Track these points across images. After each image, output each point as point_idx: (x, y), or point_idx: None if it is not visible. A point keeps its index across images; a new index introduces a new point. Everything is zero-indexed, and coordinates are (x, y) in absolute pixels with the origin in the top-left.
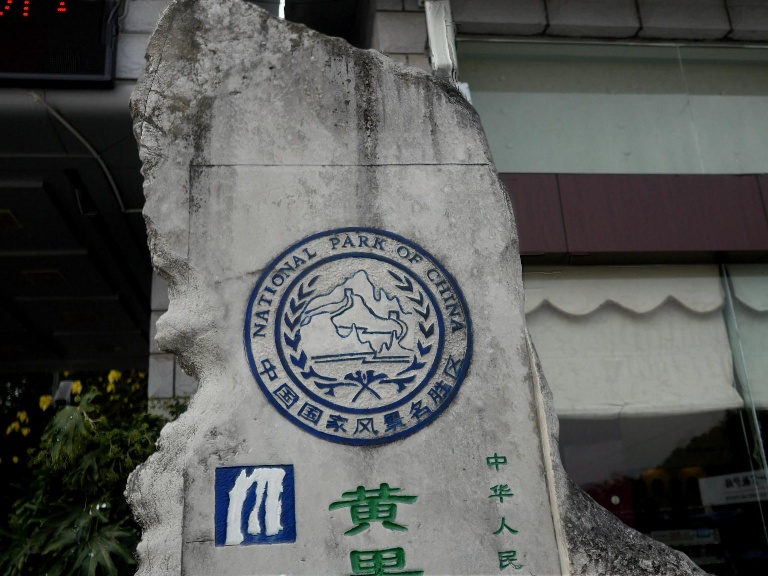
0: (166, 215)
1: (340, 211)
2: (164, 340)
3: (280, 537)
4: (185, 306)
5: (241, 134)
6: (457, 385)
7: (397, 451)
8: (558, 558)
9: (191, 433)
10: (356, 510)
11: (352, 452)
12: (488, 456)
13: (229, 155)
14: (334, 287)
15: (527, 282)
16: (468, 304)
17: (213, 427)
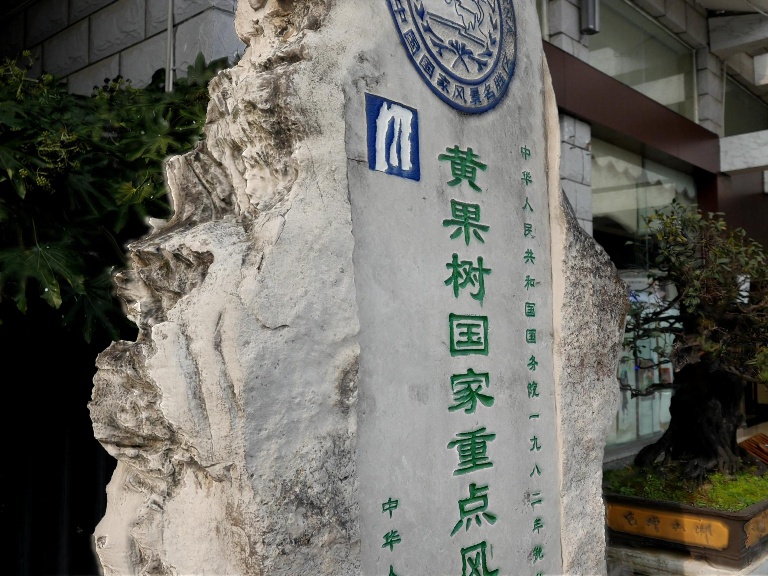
0: None
1: None
2: None
3: (410, 173)
4: None
5: None
6: (509, 80)
7: (477, 123)
8: (550, 235)
9: (340, 49)
10: (453, 165)
11: (452, 113)
12: (522, 146)
13: None
14: None
15: None
16: (515, 12)
17: (361, 50)
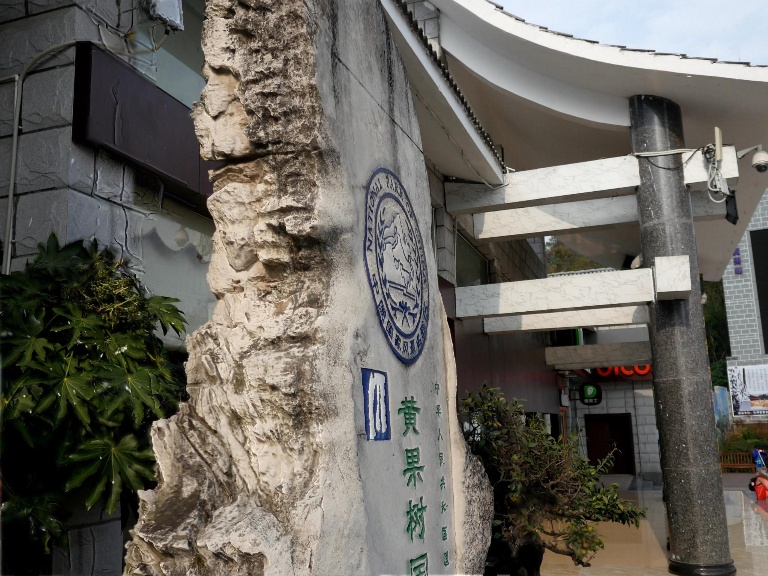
0: (326, 96)
1: (388, 154)
2: (323, 229)
3: (386, 435)
4: (335, 200)
5: (350, 40)
6: (427, 326)
7: None
8: (451, 459)
9: (344, 330)
10: (405, 416)
11: None
12: None
13: (347, 57)
14: (391, 222)
15: (177, 207)
16: None
17: (357, 328)
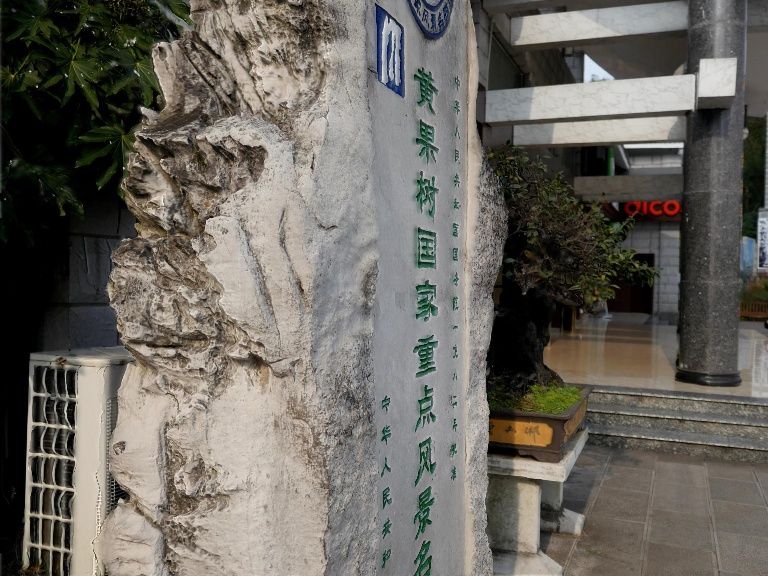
0: None
1: None
2: None
3: (399, 90)
4: None
5: None
6: None
7: (434, 48)
8: (467, 163)
9: None
10: (421, 87)
11: None
12: None
13: None
14: None
15: None
16: None
17: None
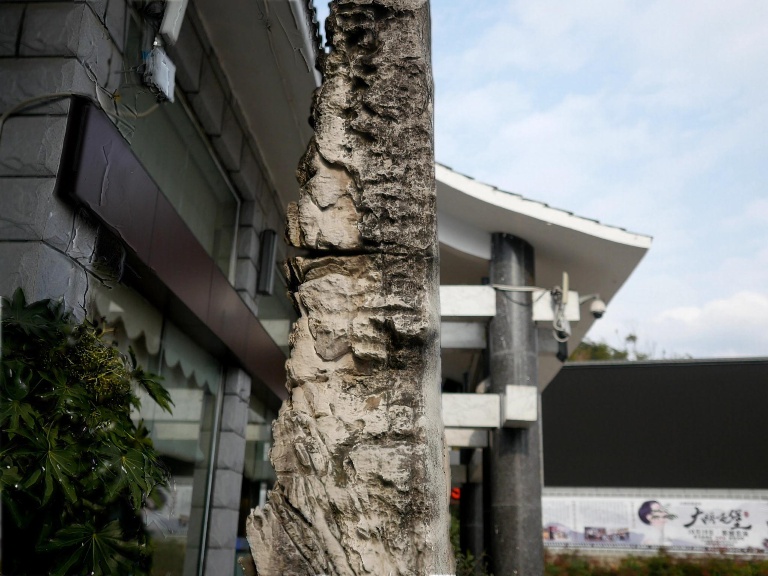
0: None
1: None
2: (430, 332)
3: None
4: None
5: None
6: None
7: None
8: None
9: None
10: None
11: None
12: None
13: None
14: None
15: (128, 277)
16: None
17: None
